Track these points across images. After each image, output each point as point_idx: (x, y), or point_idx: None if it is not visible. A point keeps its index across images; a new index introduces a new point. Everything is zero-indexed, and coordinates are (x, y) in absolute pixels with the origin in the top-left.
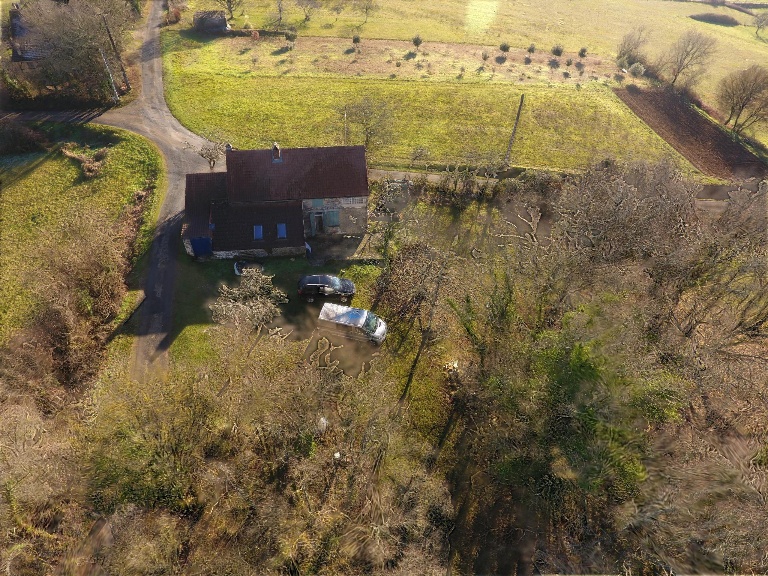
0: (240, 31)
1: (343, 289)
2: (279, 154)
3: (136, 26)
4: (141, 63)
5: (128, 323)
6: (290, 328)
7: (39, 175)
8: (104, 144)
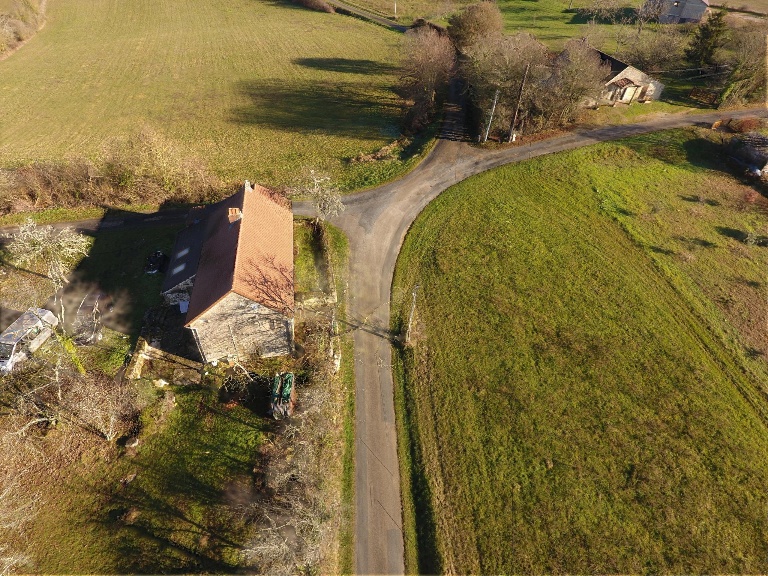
0: (767, 184)
1: (75, 330)
2: (232, 220)
3: (682, 111)
4: (575, 134)
5: (119, 211)
6: (63, 301)
7: (364, 143)
8: (407, 156)
